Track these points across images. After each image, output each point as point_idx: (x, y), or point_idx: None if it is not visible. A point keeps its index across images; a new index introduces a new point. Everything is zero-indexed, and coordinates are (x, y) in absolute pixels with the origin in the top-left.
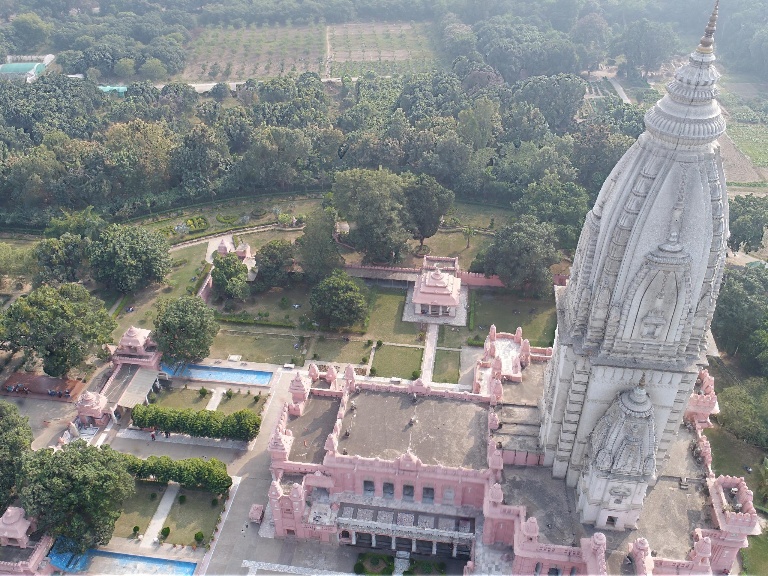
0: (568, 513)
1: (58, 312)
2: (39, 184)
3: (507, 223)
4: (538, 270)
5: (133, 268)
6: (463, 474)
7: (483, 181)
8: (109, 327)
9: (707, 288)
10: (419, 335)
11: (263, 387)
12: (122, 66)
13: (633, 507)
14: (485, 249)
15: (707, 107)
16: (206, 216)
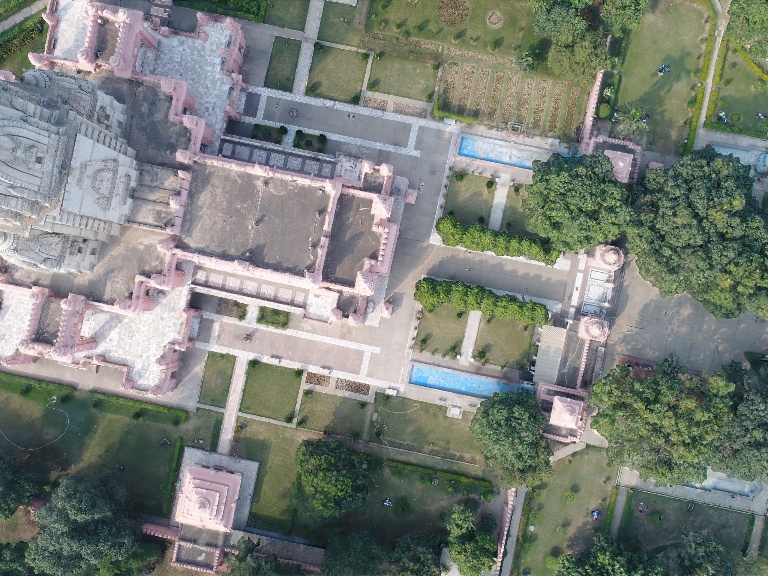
0: (135, 115)
1: None
2: None
3: None
4: None
5: None
6: None
7: None
8: None
9: None
10: None
11: (419, 361)
12: None
13: None
14: None
15: None
16: None
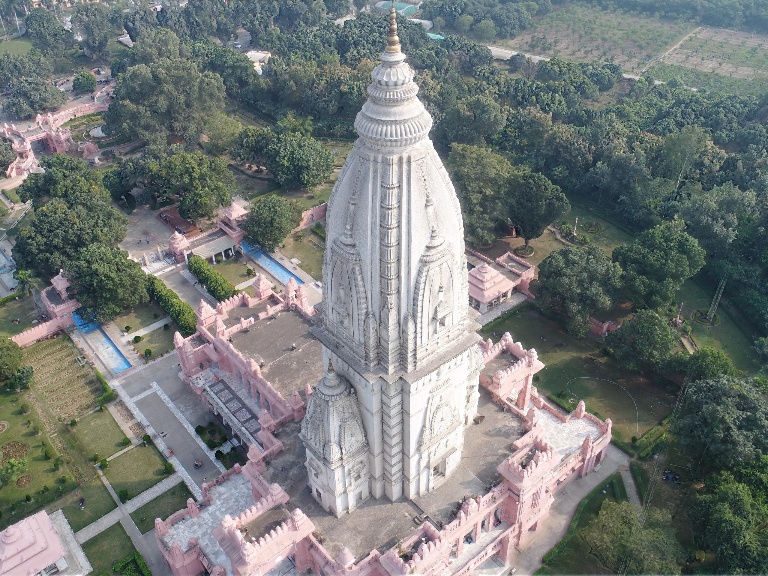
0: None
1: (189, 170)
2: (293, 90)
3: None
4: (567, 302)
5: (287, 168)
6: (279, 399)
7: (646, 212)
8: (222, 197)
9: (385, 299)
10: None
11: None
12: (460, 21)
13: (329, 490)
14: None
15: (384, 108)
16: None
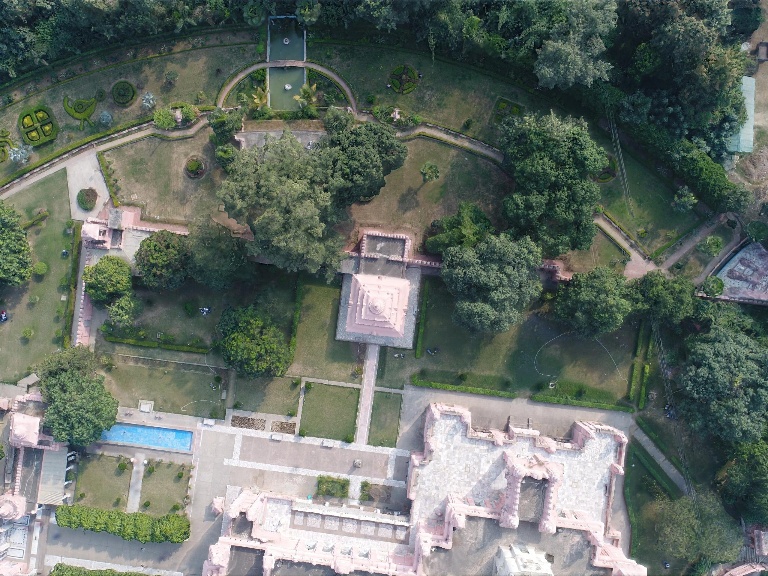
0: None
1: None
2: None
3: (491, 119)
4: None
5: None
6: None
7: None
8: None
9: None
10: (355, 372)
11: (185, 454)
12: None
13: None
14: (452, 183)
15: None
16: (47, 101)
